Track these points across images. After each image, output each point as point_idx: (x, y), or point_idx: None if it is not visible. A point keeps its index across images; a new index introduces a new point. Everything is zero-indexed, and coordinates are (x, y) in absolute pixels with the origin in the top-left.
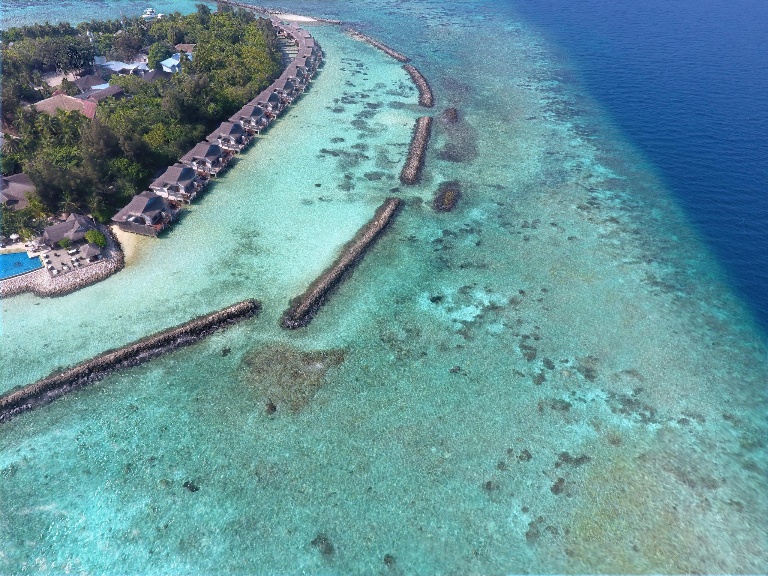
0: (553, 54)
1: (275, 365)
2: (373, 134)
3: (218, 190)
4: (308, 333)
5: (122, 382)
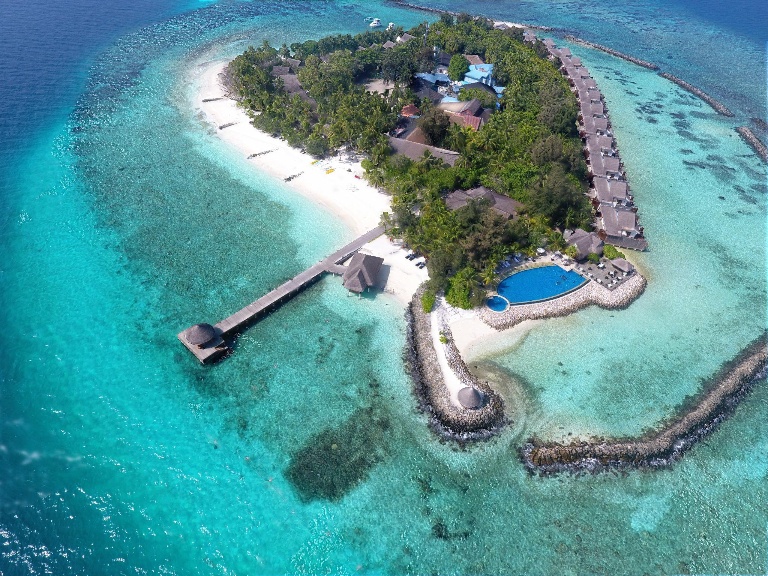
0: None
1: None
2: (712, 145)
3: (638, 203)
4: None
5: None
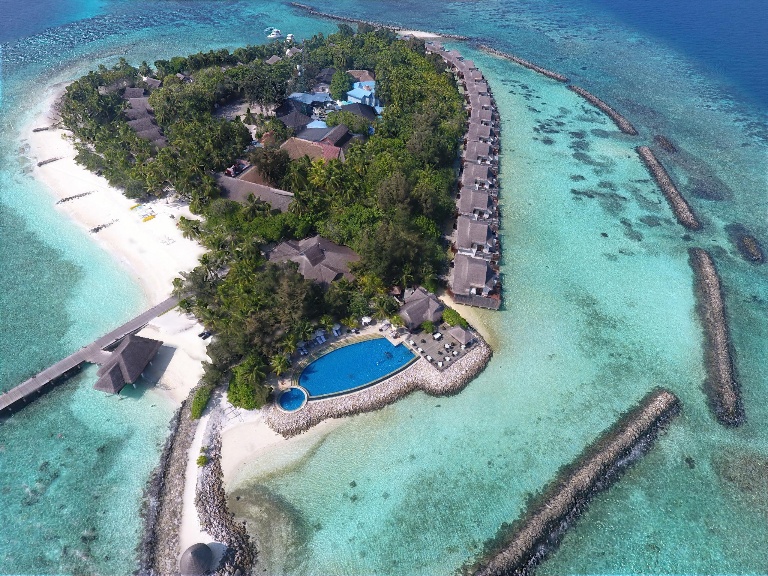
0: (699, 68)
1: (759, 478)
2: (607, 169)
3: (509, 245)
4: (755, 431)
5: (613, 511)
